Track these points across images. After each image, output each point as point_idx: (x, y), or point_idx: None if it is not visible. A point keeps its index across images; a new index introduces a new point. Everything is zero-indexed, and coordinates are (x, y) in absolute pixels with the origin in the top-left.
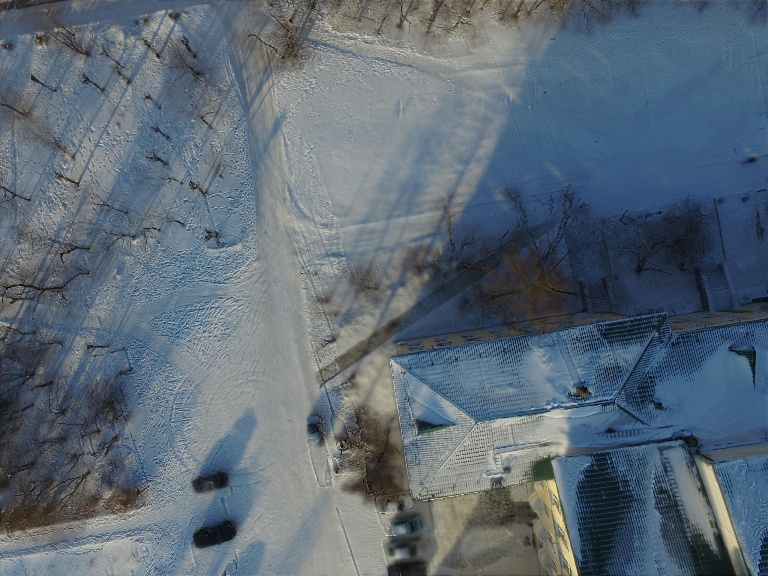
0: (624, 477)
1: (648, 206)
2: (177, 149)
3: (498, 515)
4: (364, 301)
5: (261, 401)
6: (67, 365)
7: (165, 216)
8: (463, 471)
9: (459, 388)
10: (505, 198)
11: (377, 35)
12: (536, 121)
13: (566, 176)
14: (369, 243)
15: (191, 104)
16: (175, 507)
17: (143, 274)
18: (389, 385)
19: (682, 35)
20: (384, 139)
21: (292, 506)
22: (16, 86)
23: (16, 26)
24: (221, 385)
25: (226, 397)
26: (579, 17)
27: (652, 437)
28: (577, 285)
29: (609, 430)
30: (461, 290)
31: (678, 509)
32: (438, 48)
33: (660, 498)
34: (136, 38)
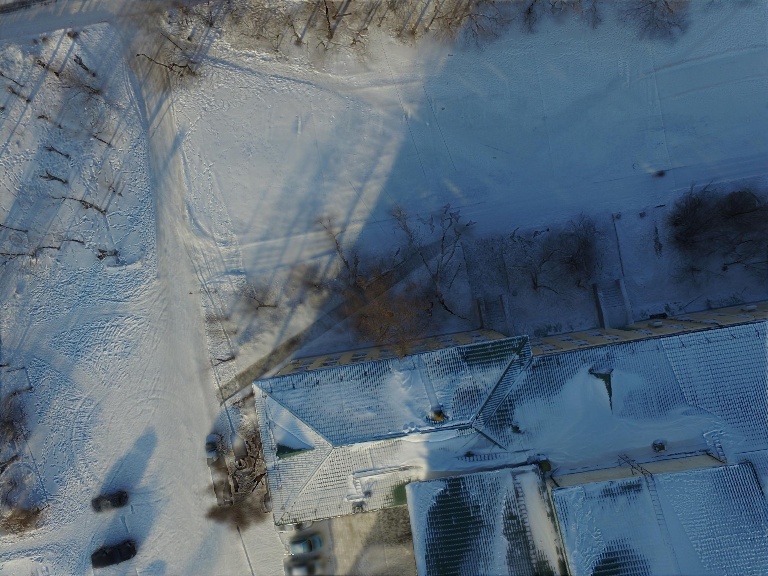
0: (475, 502)
1: (546, 222)
2: (76, 167)
3: (396, 533)
4: (263, 319)
5: (161, 419)
6: None
7: (64, 234)
8: (324, 495)
9: (319, 412)
10: None
11: (275, 52)
12: (434, 138)
13: (464, 192)
14: (269, 260)
15: (90, 122)
16: (76, 526)
17: (43, 293)
18: None
19: (579, 51)
20: (282, 156)
21: (193, 525)
22: None
23: None
24: (121, 403)
25: (126, 415)
26: (466, 35)
27: (508, 461)
28: (476, 302)
29: (468, 454)
30: (360, 307)
31: (526, 535)
32: (336, 65)
33: (509, 524)
34: (35, 57)
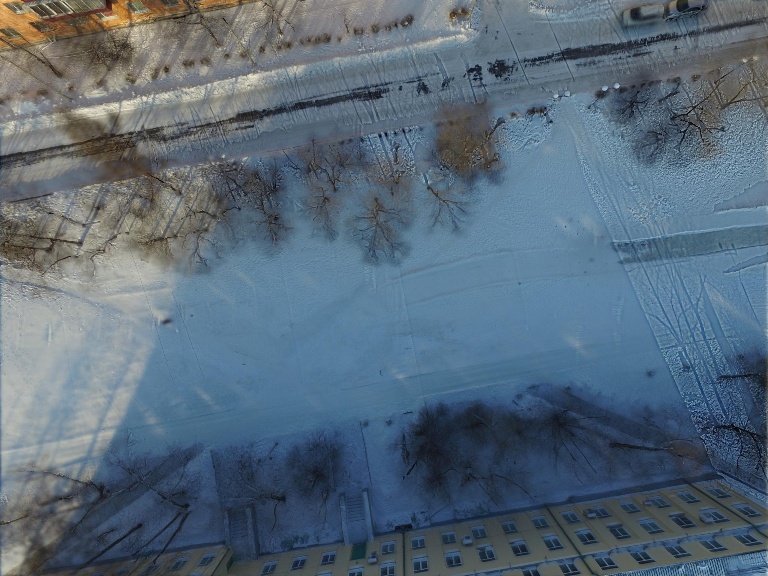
0: None
1: (295, 430)
2: None
3: None
4: (15, 528)
5: None
6: None
7: None
8: None
9: None
10: None
11: (27, 260)
12: (183, 345)
13: (213, 400)
14: (21, 468)
15: None
16: None
17: None
18: None
19: (326, 257)
20: (33, 365)
21: None
22: None
23: None
24: None
25: None
26: (190, 261)
27: None
28: None
29: None
30: (111, 516)
31: None
32: (86, 272)
33: None
34: None
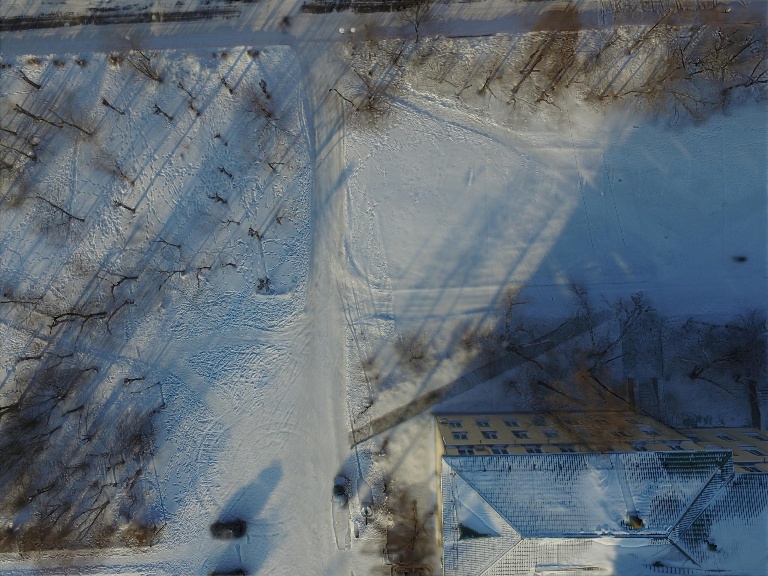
0: None
1: (710, 311)
2: (238, 189)
3: None
4: (407, 368)
5: (290, 454)
6: (100, 391)
7: (217, 255)
8: None
9: (509, 499)
10: (565, 283)
11: (456, 99)
12: (607, 209)
13: (630, 269)
14: (420, 309)
15: (258, 145)
16: (190, 548)
17: (188, 310)
18: (421, 456)
19: None
20: (449, 206)
21: (307, 563)
22: (84, 103)
23: (92, 42)
24: (251, 432)
25: (255, 445)
26: (670, 115)
27: None
28: (626, 381)
29: (657, 564)
30: (507, 370)
31: None
32: (517, 121)
33: None
34: (211, 71)
